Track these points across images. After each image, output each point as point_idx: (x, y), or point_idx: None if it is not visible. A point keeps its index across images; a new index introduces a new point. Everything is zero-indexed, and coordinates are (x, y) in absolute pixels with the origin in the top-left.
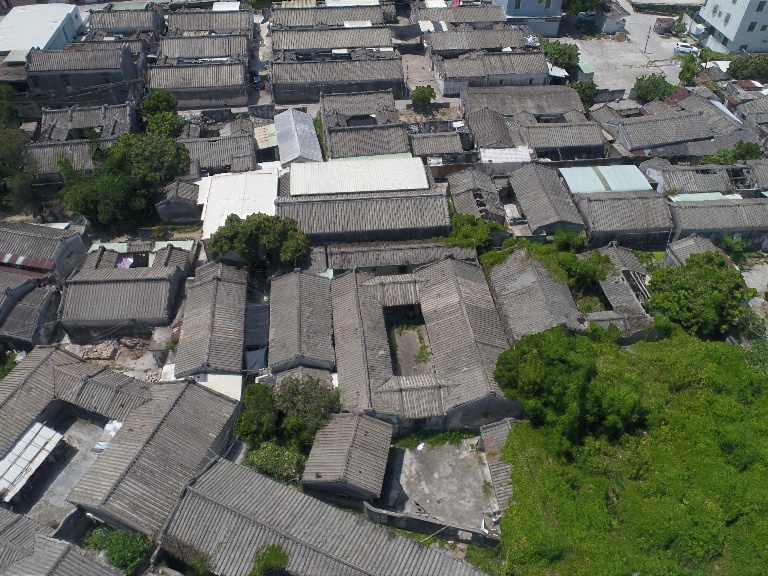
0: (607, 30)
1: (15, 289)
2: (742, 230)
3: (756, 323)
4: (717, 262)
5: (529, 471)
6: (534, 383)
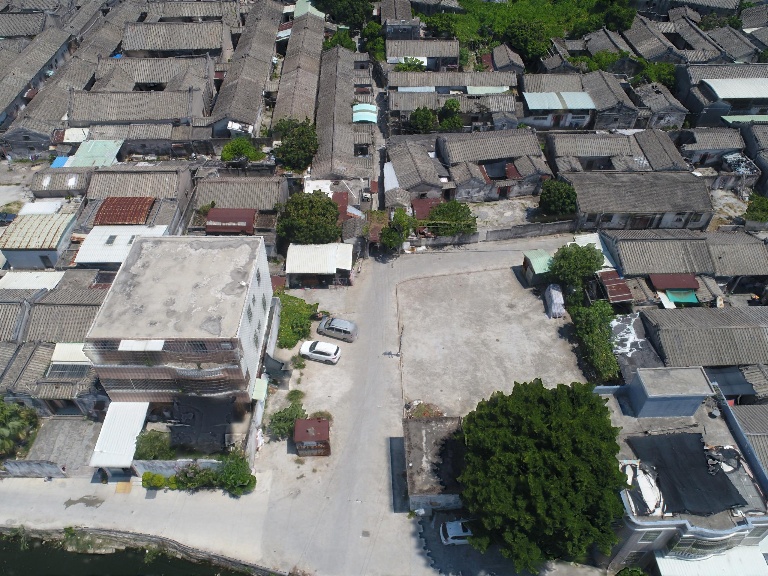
0: None
1: None
2: None
3: None
4: None
5: None
6: None
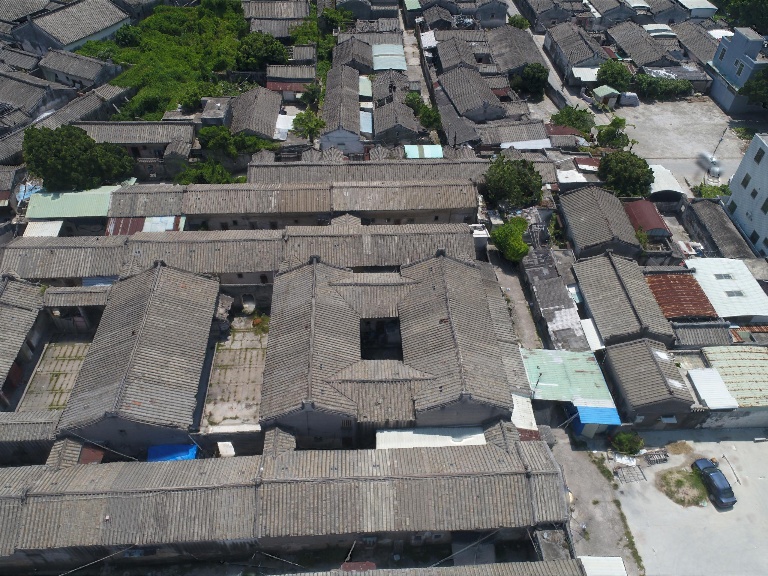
0: None
1: None
2: None
3: None
4: None
5: (185, 8)
6: None
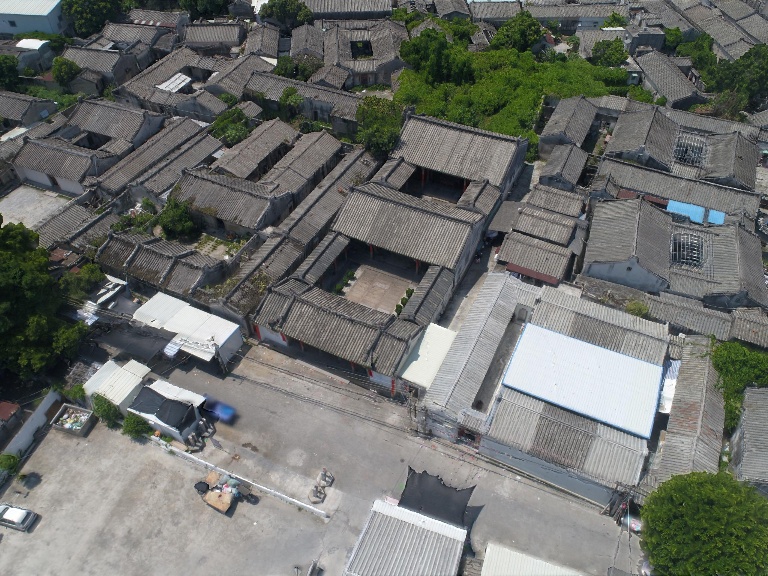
0: None
1: (160, 29)
2: (561, 20)
3: (550, 52)
4: (526, 14)
5: (408, 79)
6: (414, 45)
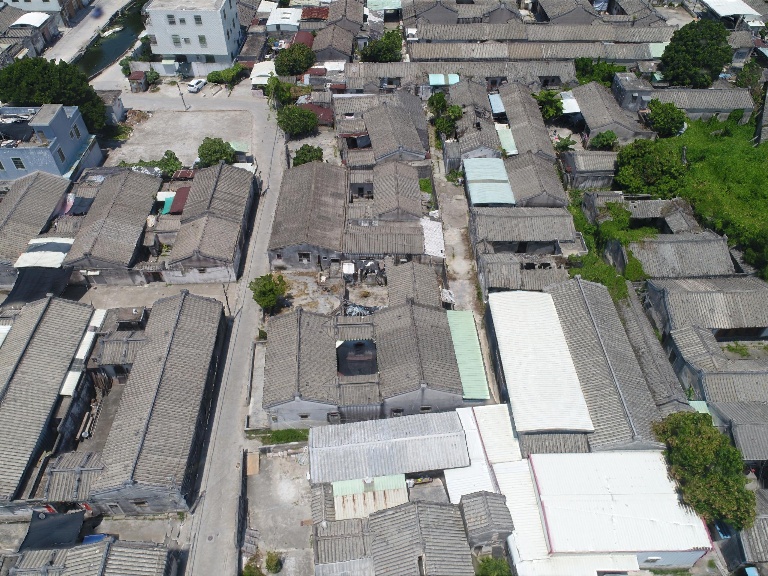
0: (118, 118)
1: None
2: None
3: None
4: None
5: None
6: None
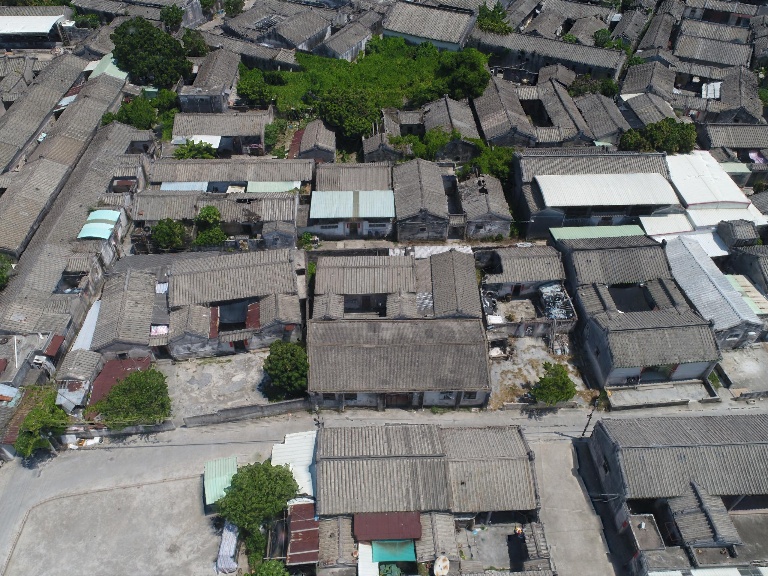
0: None
1: None
2: None
3: None
4: None
5: None
6: None
